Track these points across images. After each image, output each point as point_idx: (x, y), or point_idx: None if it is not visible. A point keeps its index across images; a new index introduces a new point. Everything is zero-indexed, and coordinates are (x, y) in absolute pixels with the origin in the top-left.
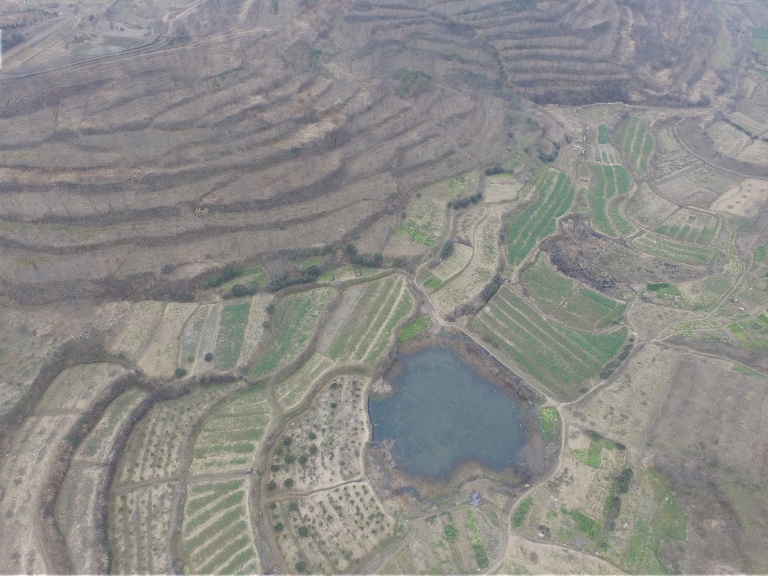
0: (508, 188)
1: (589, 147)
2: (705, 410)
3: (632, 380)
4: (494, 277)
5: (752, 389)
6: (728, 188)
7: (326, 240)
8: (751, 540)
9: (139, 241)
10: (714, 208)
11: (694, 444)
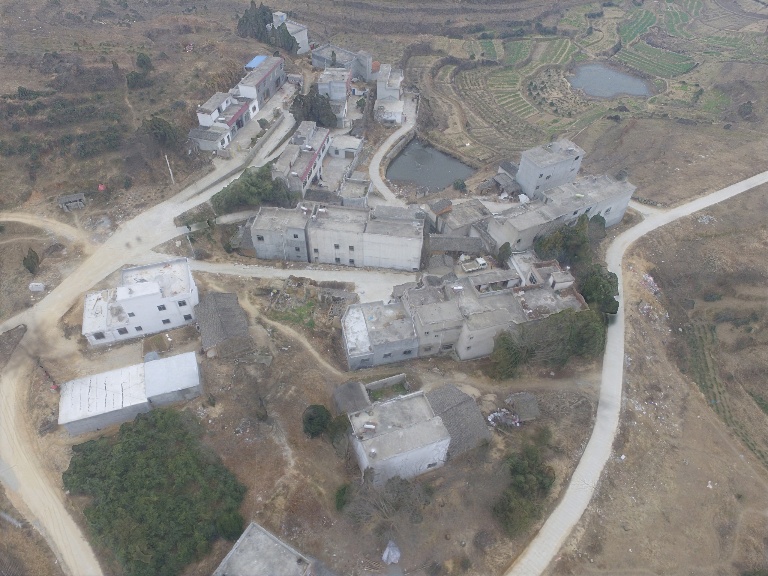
0: (617, 12)
1: (661, 4)
2: (738, 73)
3: (700, 71)
4: (618, 42)
5: (761, 66)
6: (750, 24)
7: (526, 18)
8: (759, 92)
9: (428, 11)
10: (741, 30)
11: (733, 80)
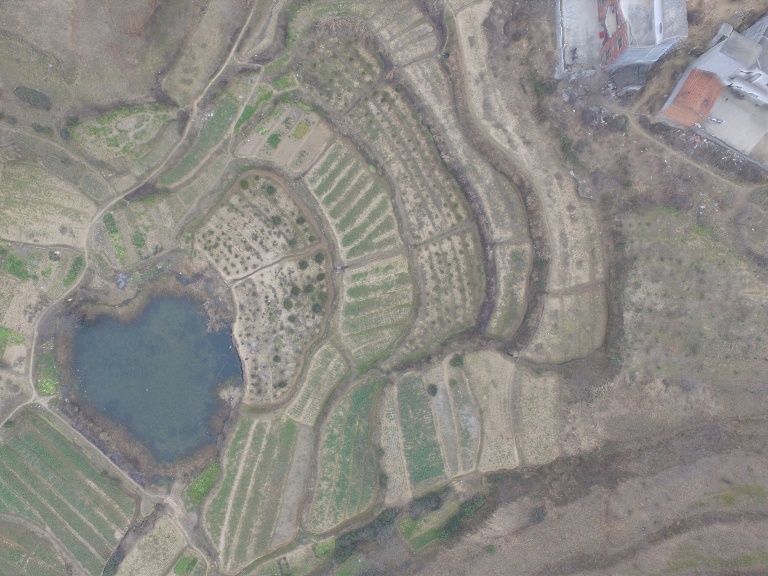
0: None
1: None
2: None
3: None
4: None
5: None
6: None
7: None
8: None
9: (602, 561)
10: None
11: None
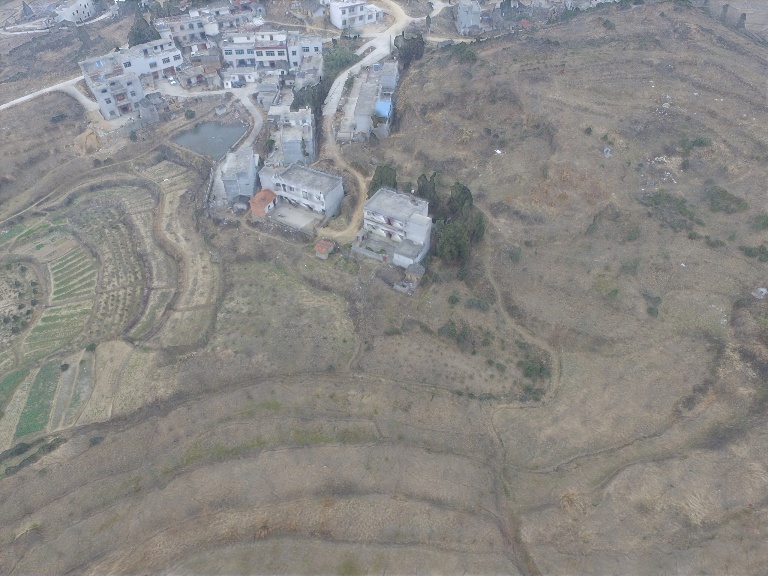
0: None
1: None
2: None
3: None
4: None
5: None
6: None
7: None
8: None
9: None
10: None
11: None
